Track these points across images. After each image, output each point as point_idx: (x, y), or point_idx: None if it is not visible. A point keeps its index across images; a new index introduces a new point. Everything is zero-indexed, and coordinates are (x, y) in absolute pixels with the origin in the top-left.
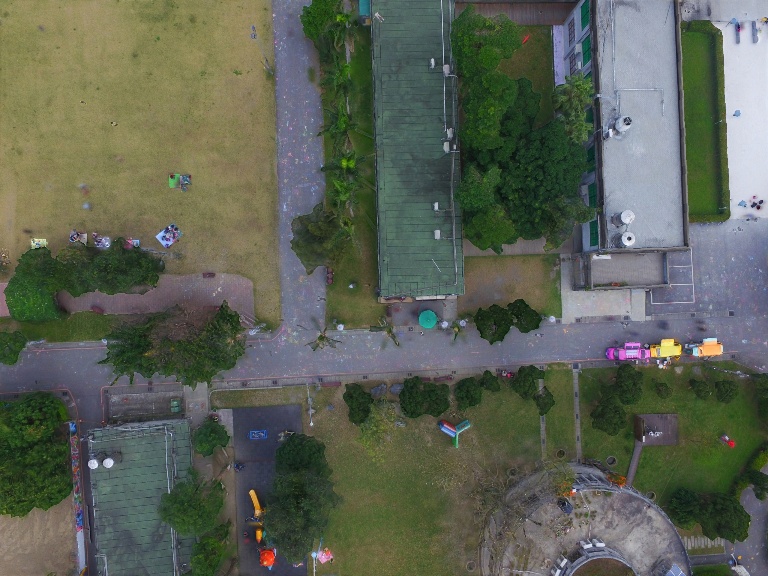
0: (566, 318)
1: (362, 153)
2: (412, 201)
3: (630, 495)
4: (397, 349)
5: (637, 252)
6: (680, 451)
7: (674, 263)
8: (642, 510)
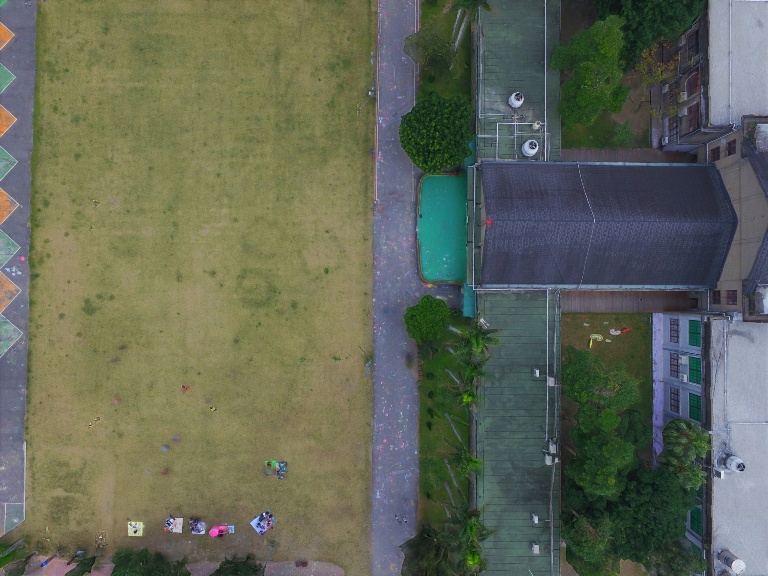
0: None
1: (457, 440)
2: (511, 510)
3: None
4: None
5: None
6: None
7: None
8: None
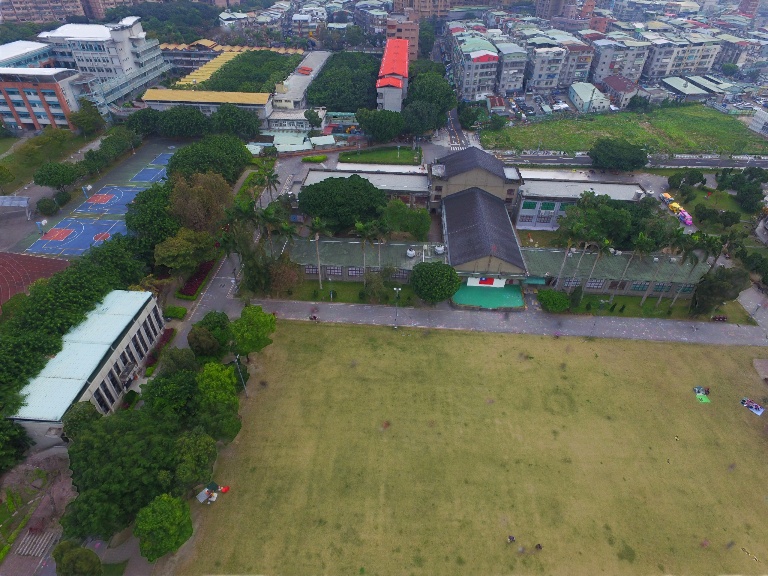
0: None
1: (624, 301)
2: None
3: None
4: (746, 295)
5: None
6: None
7: None
8: None
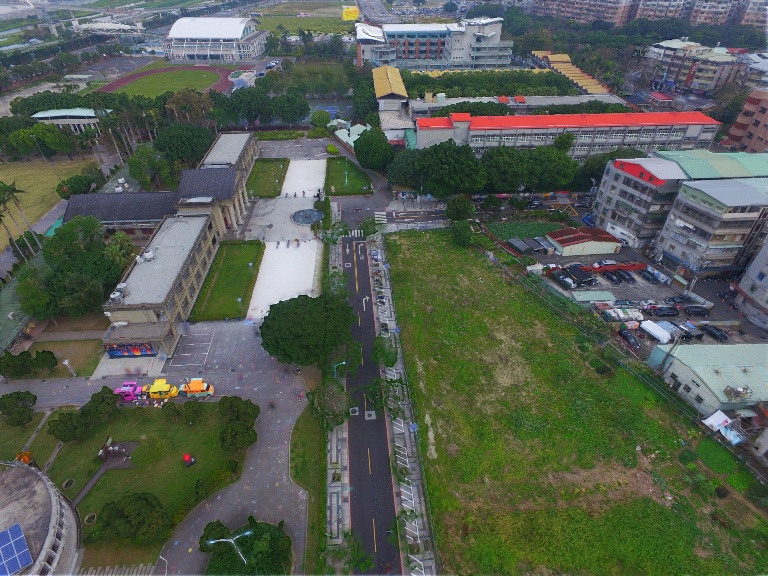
0: (95, 376)
1: None
2: (11, 303)
3: (27, 470)
4: None
5: (130, 309)
6: (143, 474)
7: (198, 342)
8: (31, 485)
